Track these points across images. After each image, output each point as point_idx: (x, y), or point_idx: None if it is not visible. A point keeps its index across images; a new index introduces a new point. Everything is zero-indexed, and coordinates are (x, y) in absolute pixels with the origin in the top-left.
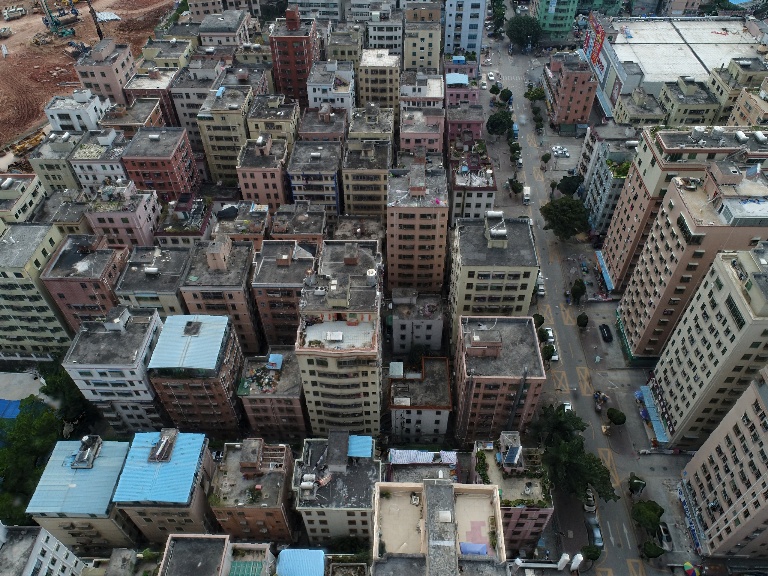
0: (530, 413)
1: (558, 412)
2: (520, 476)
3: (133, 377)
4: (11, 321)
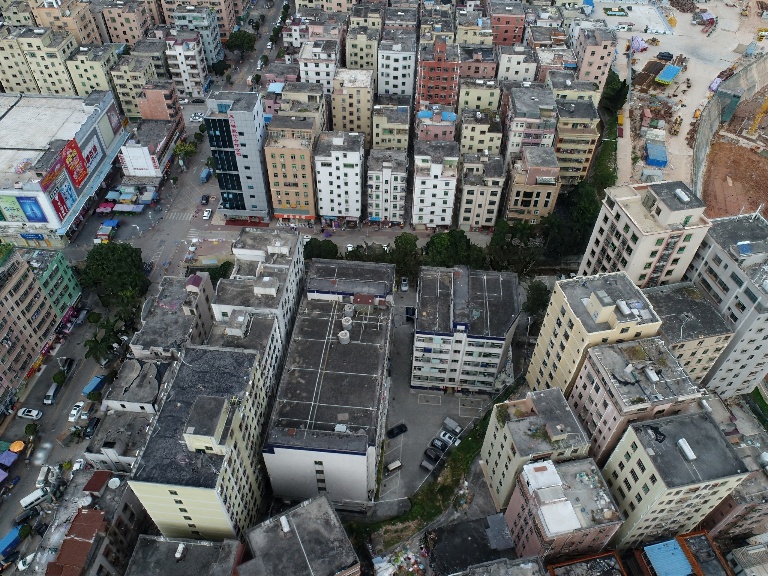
0: None
1: None
2: None
3: None
4: None
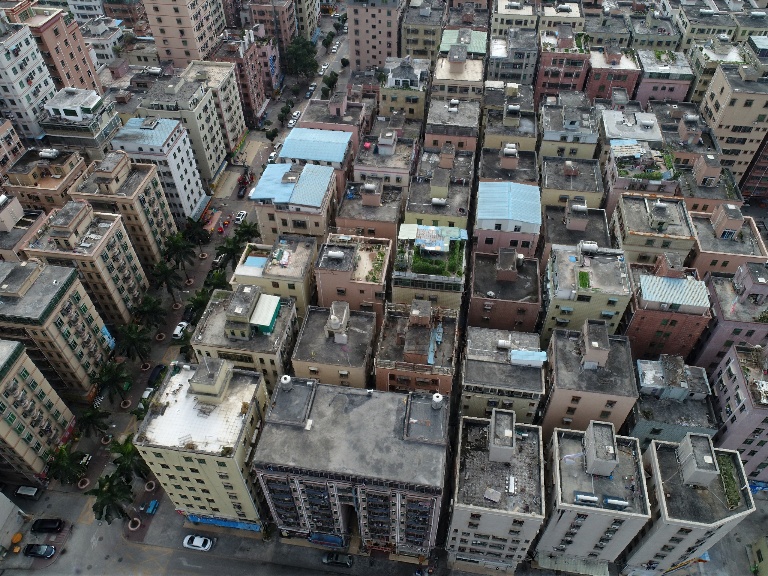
0: (286, 38)
1: (299, 37)
2: (259, 40)
3: (96, 3)
4: (46, 5)
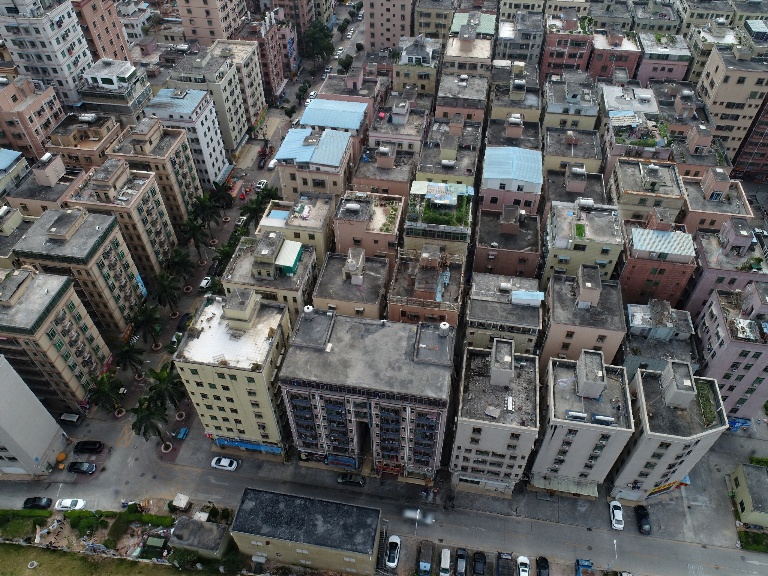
0: (304, 23)
1: (316, 21)
2: (279, 23)
3: None
4: None
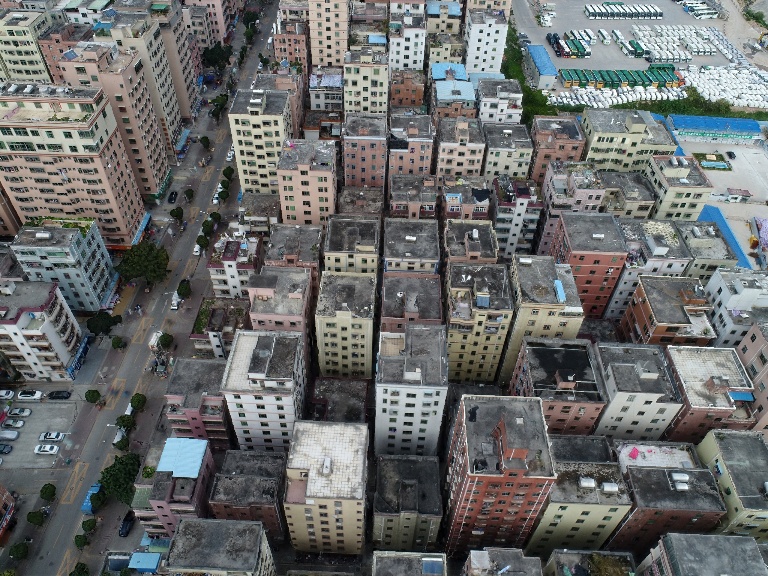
0: None
1: None
2: None
3: None
4: None
